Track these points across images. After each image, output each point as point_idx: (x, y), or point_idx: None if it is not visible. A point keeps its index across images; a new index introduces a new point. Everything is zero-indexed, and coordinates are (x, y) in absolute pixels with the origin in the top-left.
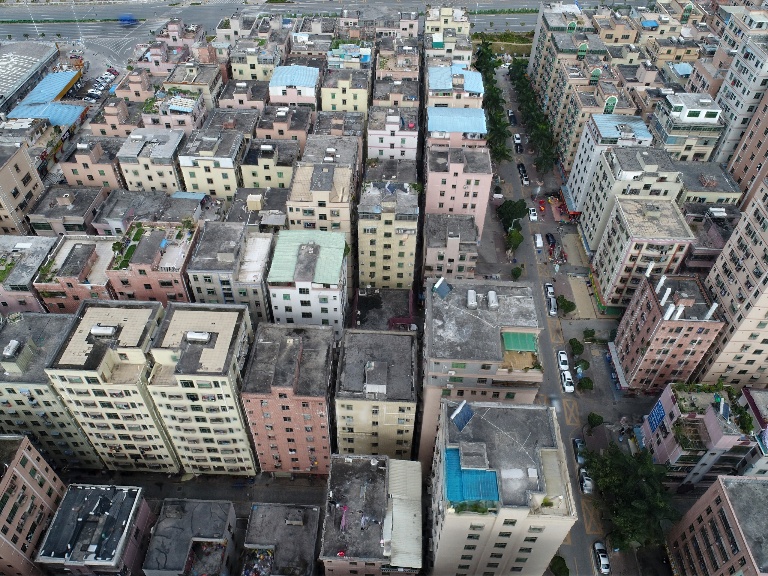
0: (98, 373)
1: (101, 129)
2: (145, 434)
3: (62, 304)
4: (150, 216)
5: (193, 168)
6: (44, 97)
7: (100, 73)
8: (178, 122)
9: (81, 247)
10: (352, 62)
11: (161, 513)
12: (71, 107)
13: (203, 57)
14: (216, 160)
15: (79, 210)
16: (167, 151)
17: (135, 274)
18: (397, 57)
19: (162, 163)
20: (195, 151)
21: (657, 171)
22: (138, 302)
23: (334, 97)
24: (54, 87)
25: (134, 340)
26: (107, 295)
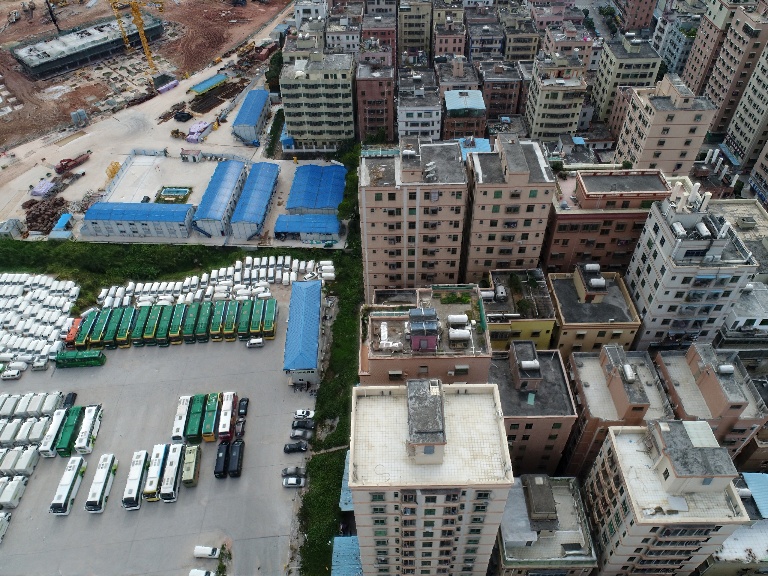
0: None
1: None
2: None
3: None
4: None
5: None
6: None
7: None
8: None
9: None
10: None
11: None
12: None
13: None
14: None
15: None
16: None
17: None
18: None
19: None
20: None
21: (761, 241)
22: None
23: None
24: None
25: None
26: None
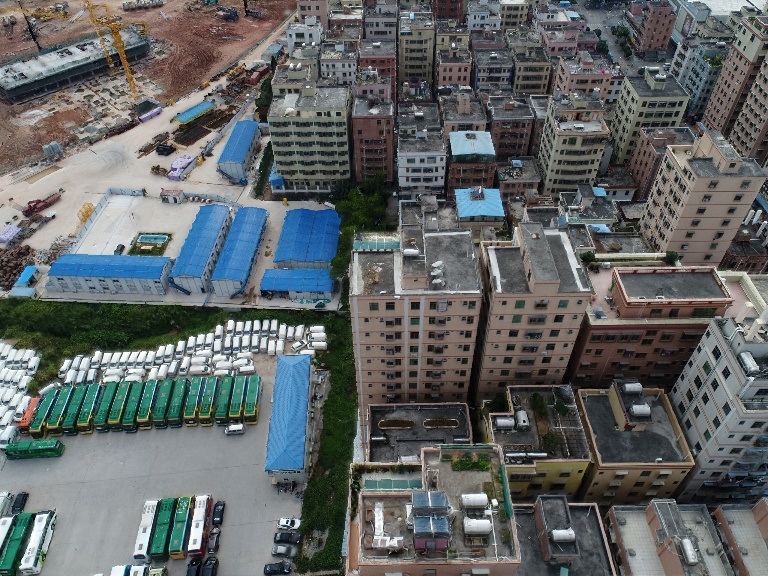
0: None
1: None
2: None
3: None
4: None
5: None
6: None
7: None
8: None
9: None
10: None
11: None
12: None
13: None
14: None
15: None
16: None
17: None
18: None
19: None
20: None
21: None
22: None
23: None
24: None
25: None
26: None
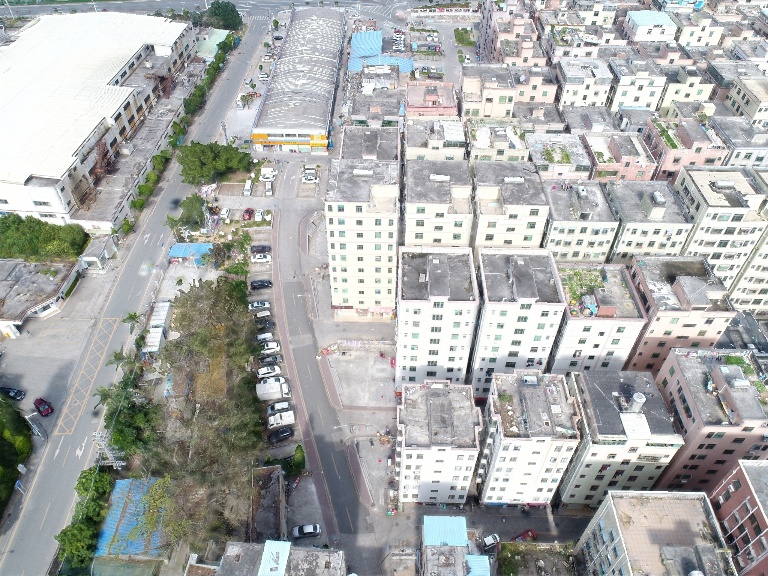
0: (748, 210)
1: (513, 62)
2: (724, 275)
3: (605, 184)
4: (609, 125)
5: (629, 87)
6: (369, 51)
7: (388, 34)
8: (585, 54)
9: (618, 137)
10: (687, 8)
11: (764, 330)
12: (399, 59)
13: (555, 6)
14: (653, 79)
15: (552, 120)
16: (606, 73)
17: (691, 152)
18: (720, 4)
19: (603, 83)
20: (629, 73)
21: None
22: (726, 167)
23: (692, 35)
24: (370, 43)
25: (750, 190)
26: (651, 174)
